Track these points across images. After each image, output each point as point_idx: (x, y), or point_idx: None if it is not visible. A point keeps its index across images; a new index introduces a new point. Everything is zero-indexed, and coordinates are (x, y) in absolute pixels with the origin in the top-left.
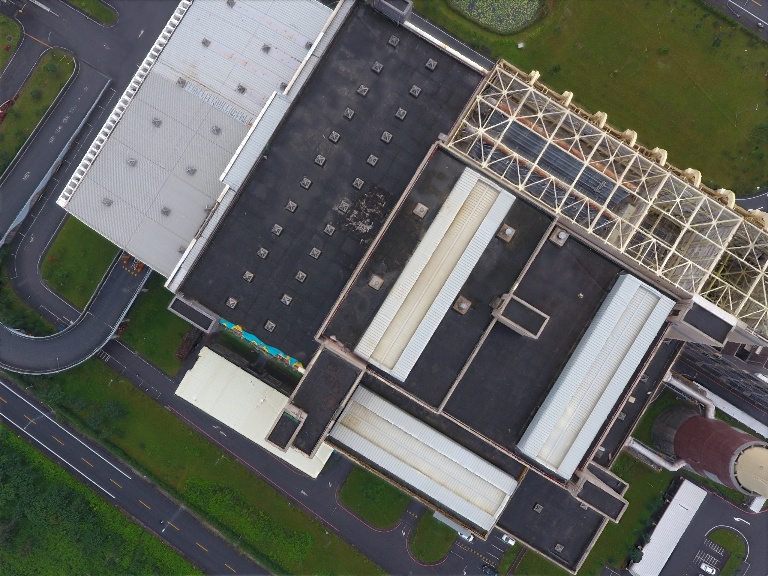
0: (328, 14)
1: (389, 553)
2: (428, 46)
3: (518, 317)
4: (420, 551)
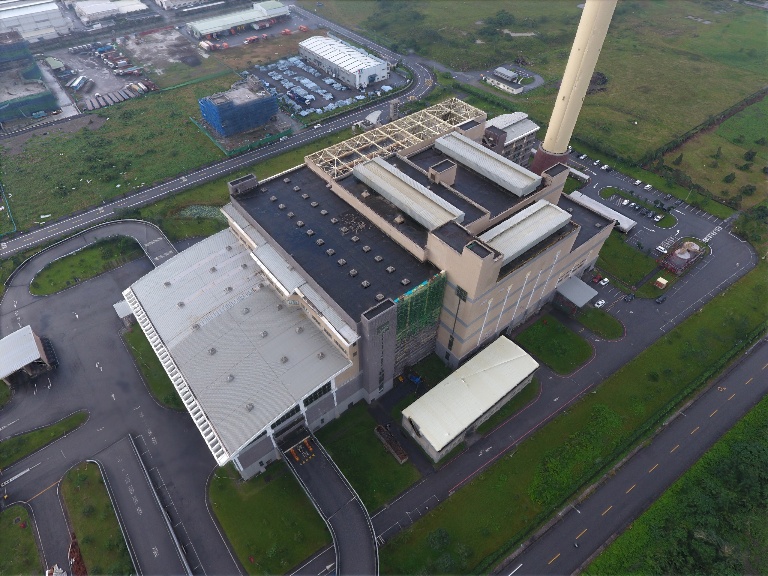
0: (217, 236)
1: (615, 354)
2: (276, 180)
3: (443, 169)
4: (613, 333)
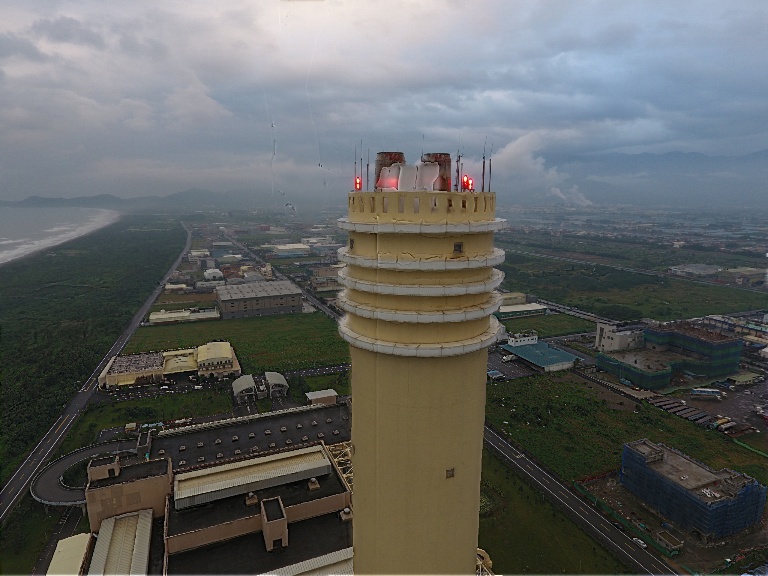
0: None
1: None
2: None
3: (270, 510)
4: None
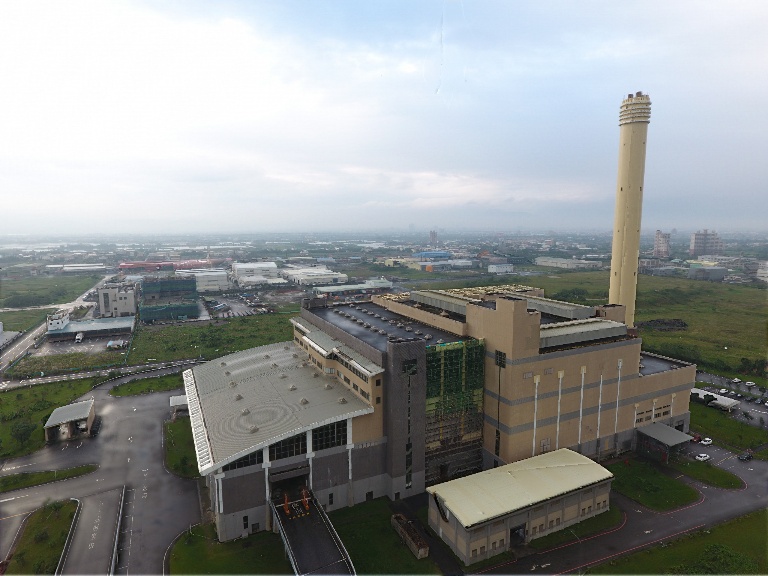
0: None
1: (733, 502)
2: None
3: None
4: (726, 483)
